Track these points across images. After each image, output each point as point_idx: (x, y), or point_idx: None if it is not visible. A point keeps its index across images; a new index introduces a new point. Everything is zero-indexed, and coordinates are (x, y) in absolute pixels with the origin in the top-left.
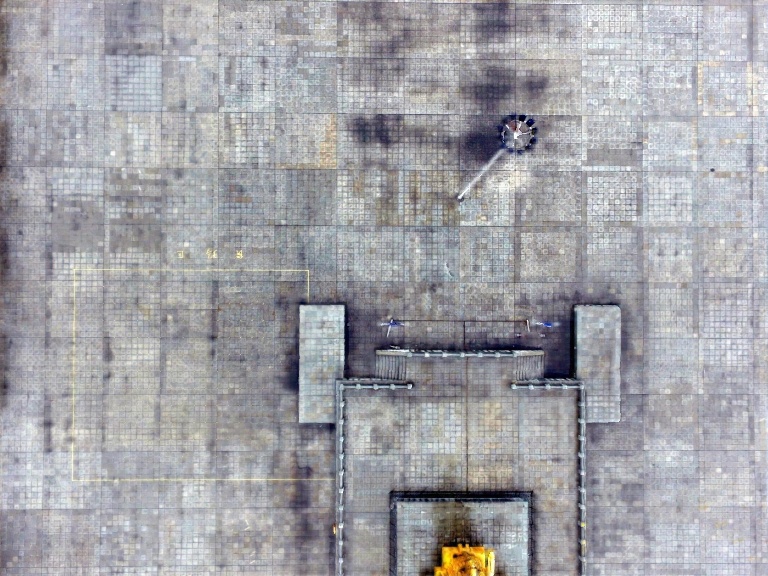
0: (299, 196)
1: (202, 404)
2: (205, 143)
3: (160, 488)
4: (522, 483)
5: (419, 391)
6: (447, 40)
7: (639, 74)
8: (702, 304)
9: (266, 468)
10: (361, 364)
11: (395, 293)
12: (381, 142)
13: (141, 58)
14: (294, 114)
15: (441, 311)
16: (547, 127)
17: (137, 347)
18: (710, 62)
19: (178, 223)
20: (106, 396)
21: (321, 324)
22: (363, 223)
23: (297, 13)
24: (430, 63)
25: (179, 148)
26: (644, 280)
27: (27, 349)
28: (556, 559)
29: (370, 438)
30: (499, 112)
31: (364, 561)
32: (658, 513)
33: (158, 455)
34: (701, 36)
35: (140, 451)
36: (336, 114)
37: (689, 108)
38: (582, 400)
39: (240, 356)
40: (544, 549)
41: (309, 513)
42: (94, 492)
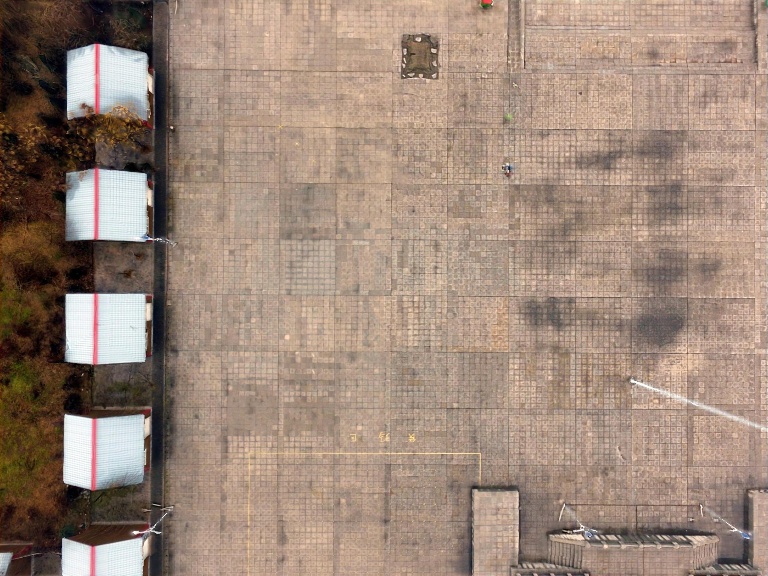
0: (471, 379)
1: None
2: (378, 326)
3: None
4: None
5: None
6: (619, 222)
7: None
8: None
9: None
10: (533, 548)
11: (567, 477)
12: (553, 325)
13: (315, 242)
14: (466, 297)
15: (613, 495)
16: (720, 310)
17: (310, 530)
18: None
19: (351, 406)
20: None
21: (495, 510)
22: (535, 406)
23: (469, 196)
24: (602, 246)
25: (352, 331)
26: None
27: (203, 532)
28: None
29: None
30: (671, 295)
31: None
32: None
33: None
34: None
35: None
36: (508, 297)
37: None
38: None
39: (412, 540)
40: None
41: None
42: None
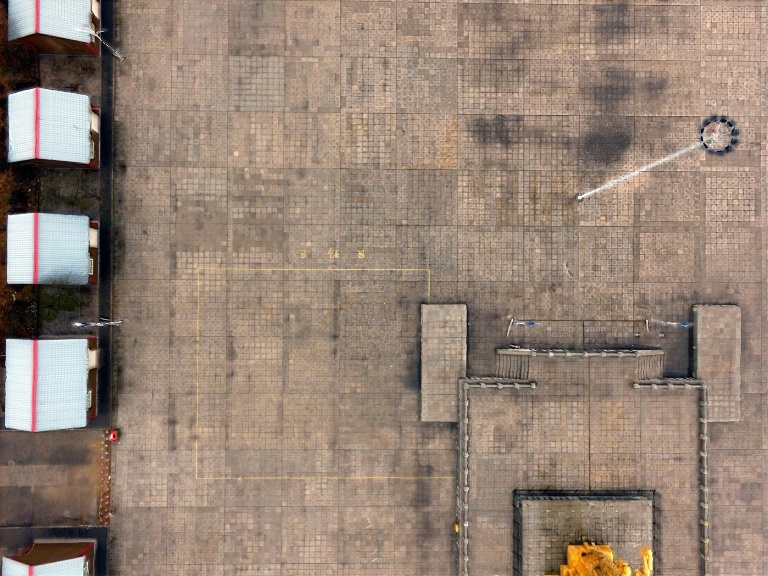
0: (420, 196)
1: (324, 402)
2: (327, 143)
3: (283, 486)
4: (644, 482)
5: (542, 390)
6: (567, 41)
7: (757, 75)
8: None
9: (387, 466)
10: (481, 363)
11: (515, 293)
12: (501, 142)
13: (264, 59)
14: (415, 115)
15: (561, 311)
16: (666, 128)
17: (260, 346)
18: None
19: (300, 223)
20: (229, 394)
21: (444, 323)
22: (483, 223)
23: (418, 14)
24: (550, 64)
25: (301, 148)
26: (762, 280)
27: (151, 347)
28: (678, 558)
29: (493, 437)
30: (618, 113)
31: (487, 559)
32: None
33: (281, 453)
34: None
35: (263, 449)
36: (457, 115)
37: None
38: (705, 400)
39: (362, 355)
40: (666, 548)
41: (430, 511)
42: (218, 490)
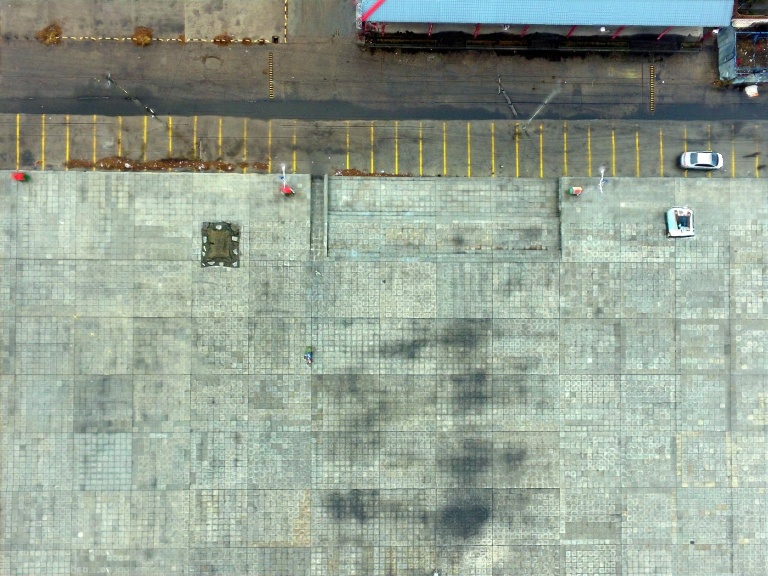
0: (272, 575)
1: None
2: (176, 522)
3: None
4: None
5: None
6: (423, 412)
7: (617, 445)
8: None
9: None
10: None
11: None
12: (356, 518)
13: (111, 435)
14: (267, 490)
15: None
16: (525, 500)
17: None
18: (689, 432)
19: None
20: None
21: None
22: None
23: (271, 387)
24: (406, 436)
25: (149, 527)
26: None
27: None
28: None
29: None
30: (476, 485)
31: None
32: None
33: None
34: (679, 406)
35: None
36: (310, 490)
37: (668, 479)
38: None
39: None
40: None
41: None
42: None
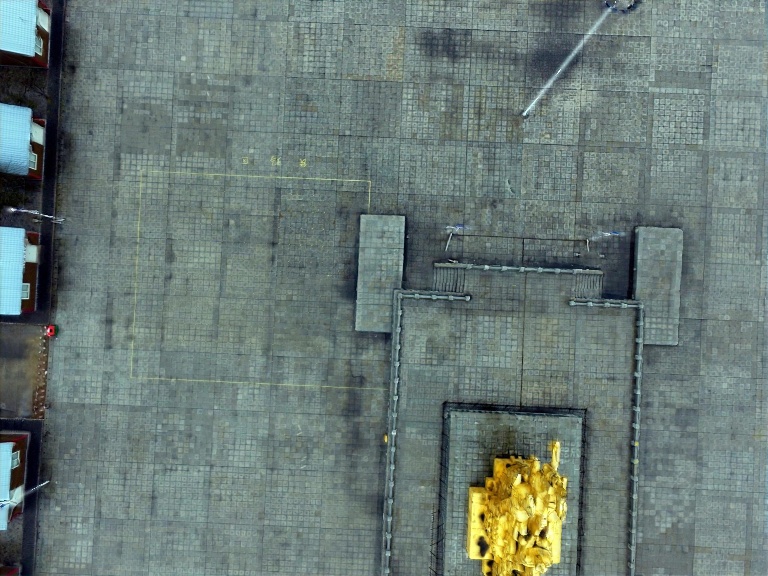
0: (364, 107)
1: (260, 309)
2: (274, 51)
3: (216, 389)
4: (576, 401)
5: (476, 304)
6: None
7: None
8: (766, 231)
9: (320, 375)
10: (419, 276)
11: (455, 207)
12: (448, 56)
13: None
14: (363, 26)
15: (501, 227)
16: (615, 47)
17: (199, 250)
18: None
19: (244, 129)
20: (167, 296)
21: (381, 234)
22: (426, 136)
23: None
24: None
25: (248, 55)
26: (707, 205)
27: (92, 246)
28: (607, 478)
29: (426, 348)
30: (568, 30)
31: (415, 470)
32: (712, 440)
33: (215, 357)
34: None
35: (198, 352)
36: (404, 27)
37: (761, 33)
38: (641, 319)
39: (299, 263)
40: (595, 468)
41: (361, 421)
42: (151, 390)
